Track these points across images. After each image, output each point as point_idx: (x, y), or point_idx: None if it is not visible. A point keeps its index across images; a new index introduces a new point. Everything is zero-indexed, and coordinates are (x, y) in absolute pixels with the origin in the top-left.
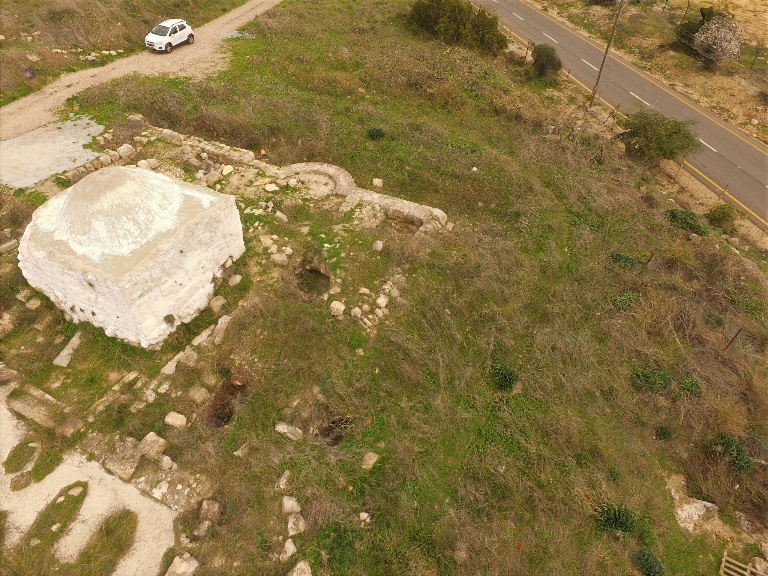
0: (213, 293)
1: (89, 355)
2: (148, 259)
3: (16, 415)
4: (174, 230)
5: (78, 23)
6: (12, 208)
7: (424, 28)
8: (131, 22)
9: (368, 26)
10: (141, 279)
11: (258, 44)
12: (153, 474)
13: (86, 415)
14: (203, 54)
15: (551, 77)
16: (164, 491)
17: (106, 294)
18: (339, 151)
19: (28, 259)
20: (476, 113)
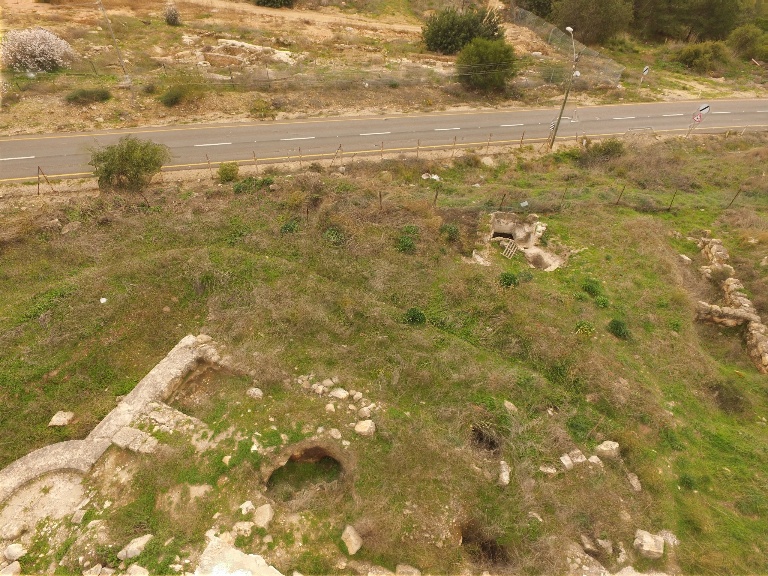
0: None
1: None
2: None
3: None
4: None
5: None
6: None
7: None
8: None
9: None
10: None
11: None
12: None
13: None
14: None
15: None
16: None
17: None
18: None
19: None
20: None
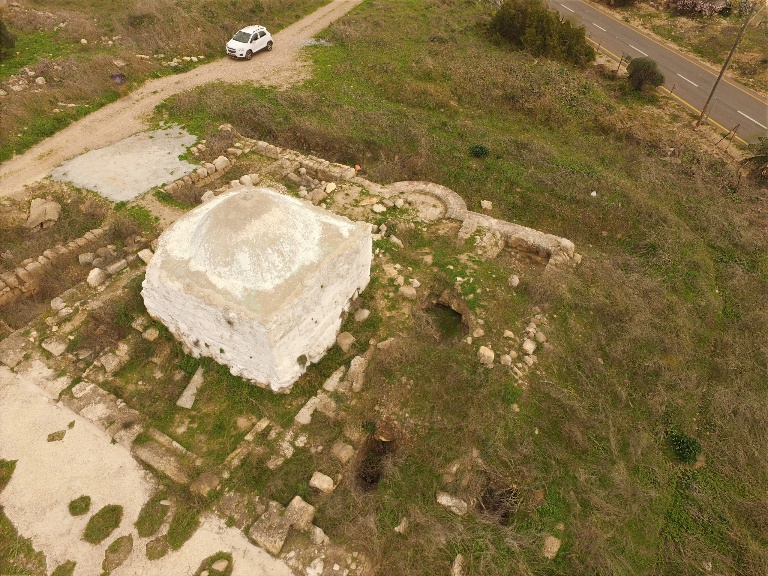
0: (340, 329)
1: (214, 396)
2: (293, 296)
3: (144, 465)
4: (317, 263)
5: (159, 28)
6: (116, 223)
7: (507, 38)
8: (211, 28)
9: (446, 35)
10: (285, 318)
11: (337, 52)
12: (304, 548)
13: (221, 470)
14: (283, 62)
15: (649, 93)
16: (320, 571)
17: (245, 333)
18: (443, 169)
19: (157, 289)
20: (580, 131)
